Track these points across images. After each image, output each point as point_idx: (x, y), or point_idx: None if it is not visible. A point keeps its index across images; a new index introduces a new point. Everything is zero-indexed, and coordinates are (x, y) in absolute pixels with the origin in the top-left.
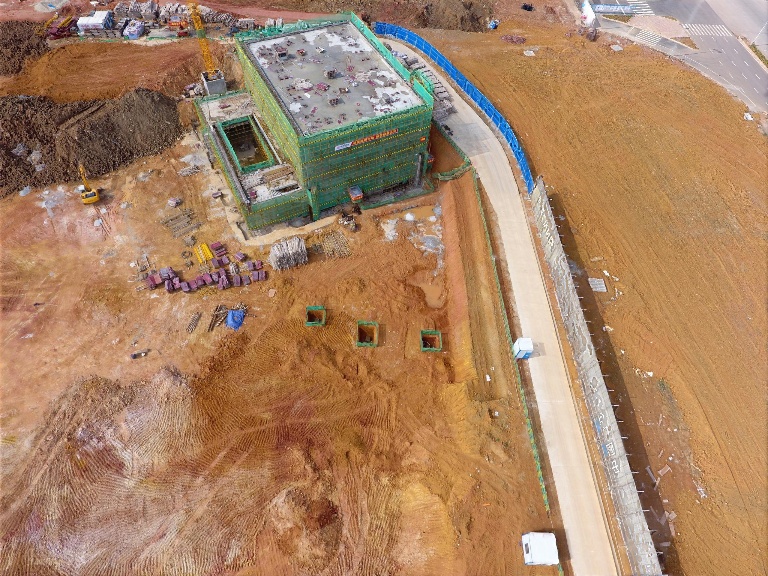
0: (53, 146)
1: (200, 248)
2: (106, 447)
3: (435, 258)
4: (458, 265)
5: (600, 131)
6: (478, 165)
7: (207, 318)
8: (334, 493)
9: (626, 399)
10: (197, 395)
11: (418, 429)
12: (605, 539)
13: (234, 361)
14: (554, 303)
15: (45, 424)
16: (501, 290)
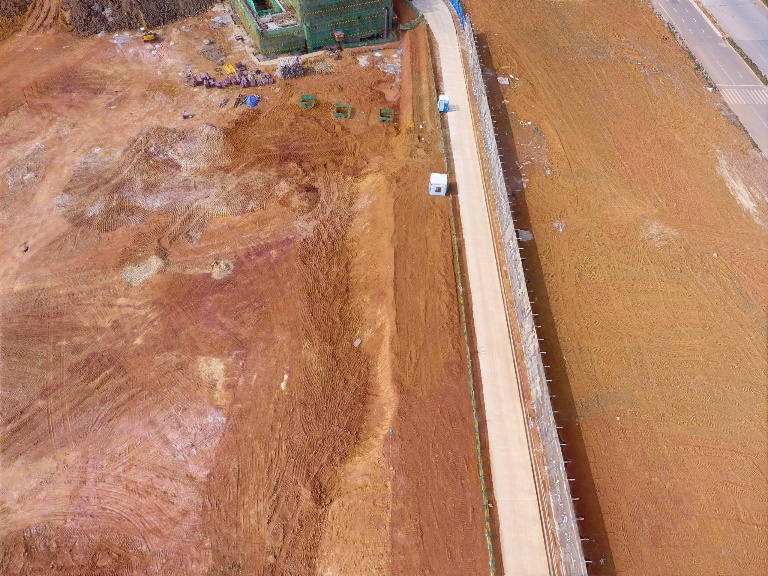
0: (120, 5)
1: (227, 66)
2: (169, 158)
3: (394, 76)
4: (409, 75)
5: (524, 2)
6: (429, 18)
7: (233, 101)
8: (316, 182)
9: (510, 134)
10: (227, 137)
11: (373, 157)
12: (481, 187)
13: (251, 122)
14: (470, 88)
15: (129, 146)
16: (435, 81)
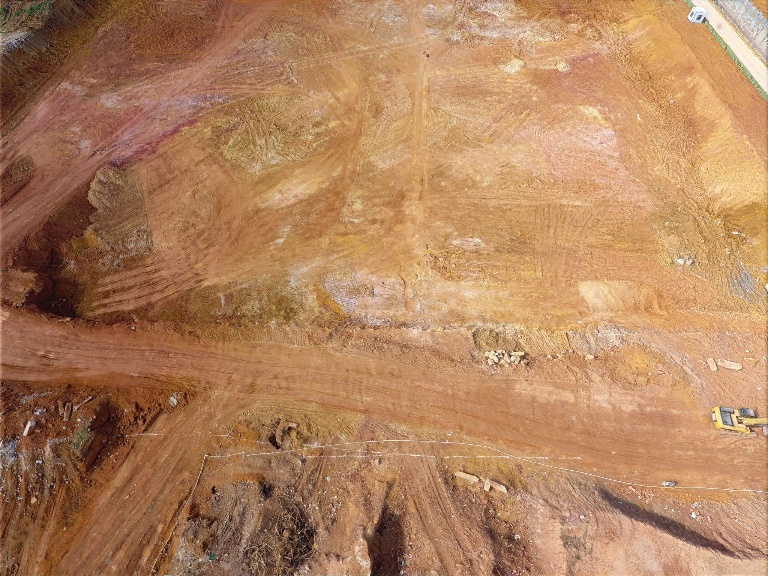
0: None
1: None
2: (484, 11)
3: None
4: None
5: None
6: None
7: None
8: None
9: None
10: (516, 0)
11: (624, 12)
12: (722, 19)
13: None
14: None
15: None
16: None
